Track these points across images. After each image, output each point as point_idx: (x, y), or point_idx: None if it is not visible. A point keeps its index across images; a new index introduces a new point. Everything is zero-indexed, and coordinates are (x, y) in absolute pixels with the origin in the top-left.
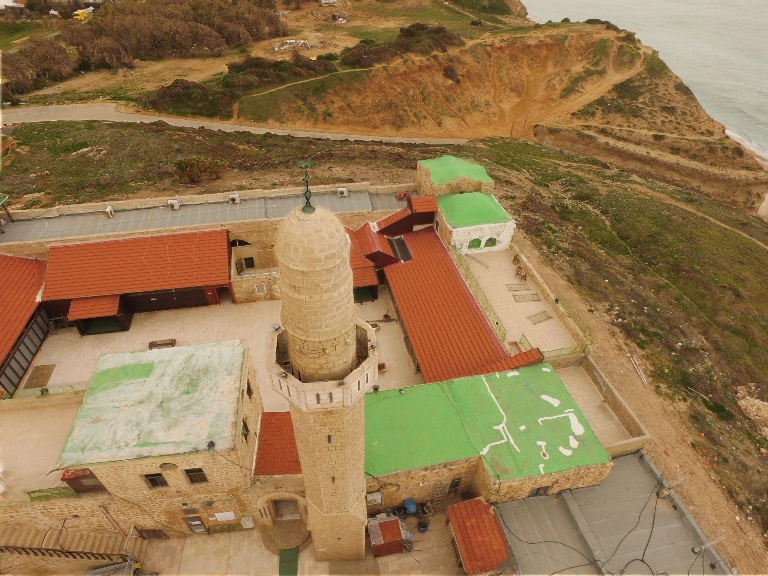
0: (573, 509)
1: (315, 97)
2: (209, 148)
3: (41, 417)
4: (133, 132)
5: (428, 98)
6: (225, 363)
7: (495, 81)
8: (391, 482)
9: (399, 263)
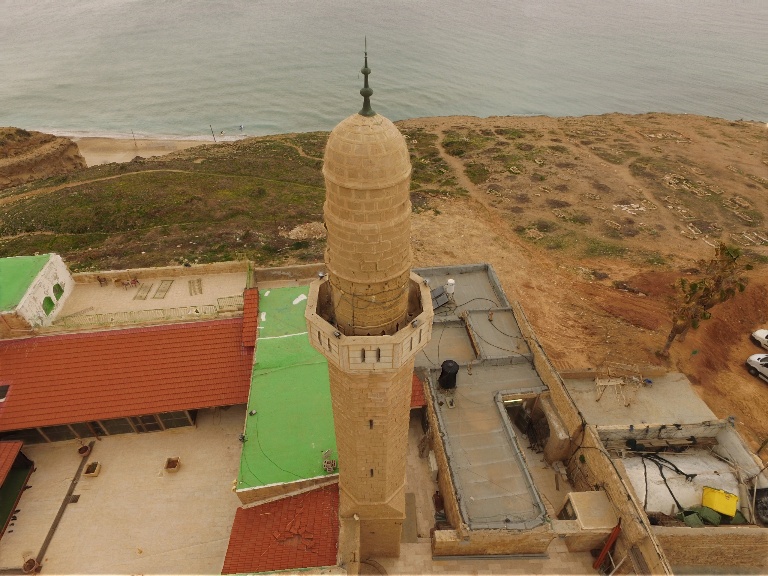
0: None
1: None
2: None
3: None
4: None
5: None
6: None
7: None
8: None
9: (0, 406)
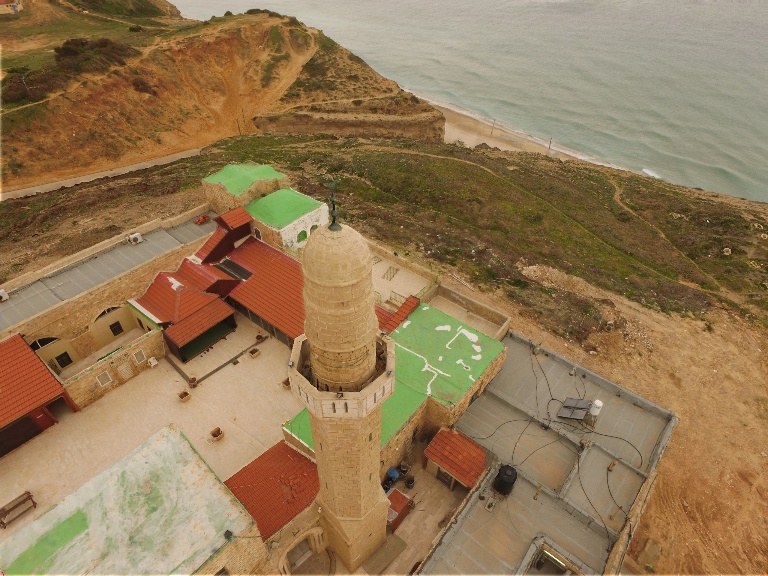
0: (499, 395)
1: None
2: None
3: None
4: None
5: (132, 118)
6: (171, 457)
7: (192, 85)
8: None
9: (242, 283)
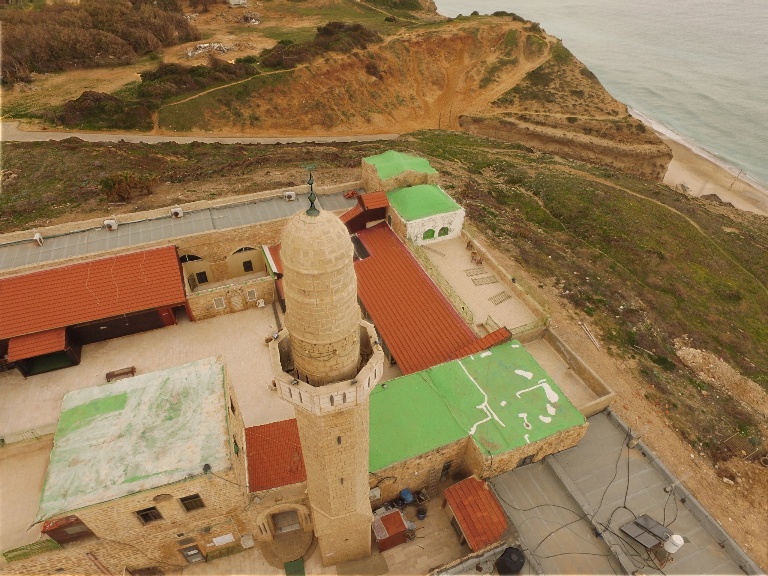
0: (558, 472)
1: (239, 102)
2: (134, 162)
3: None
4: (44, 151)
5: (354, 96)
6: (205, 382)
7: (416, 75)
8: (388, 475)
9: (358, 261)
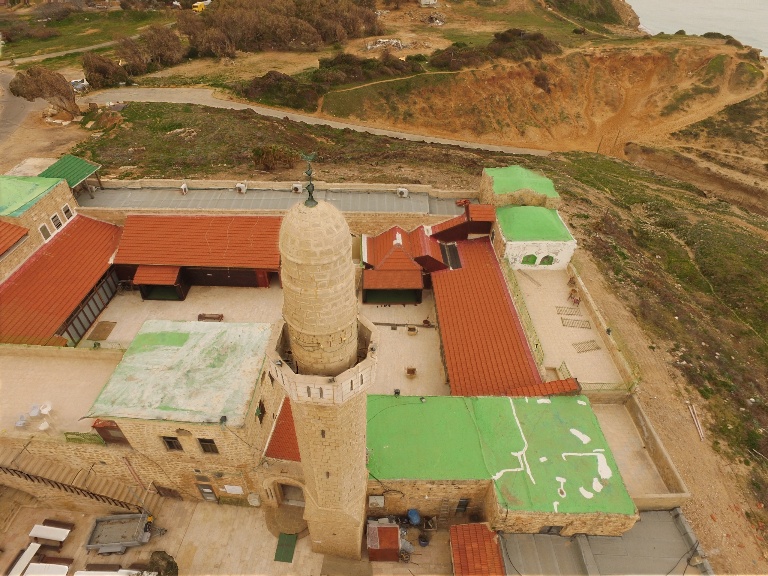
0: (586, 556)
1: (398, 97)
2: (288, 138)
3: (91, 367)
4: (223, 117)
5: (514, 106)
6: (253, 344)
7: (590, 93)
8: (396, 489)
9: (447, 270)
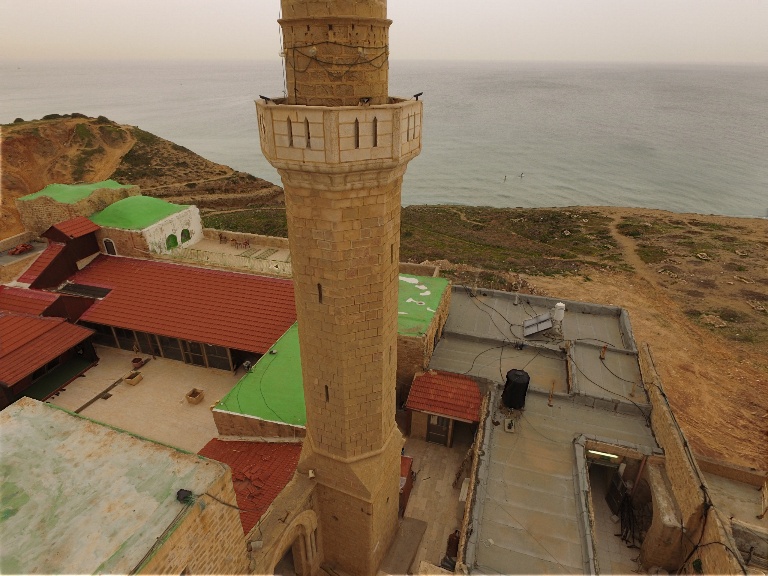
0: (460, 332)
1: None
2: None
3: None
4: None
5: None
6: (31, 436)
7: None
8: None
9: (97, 302)
